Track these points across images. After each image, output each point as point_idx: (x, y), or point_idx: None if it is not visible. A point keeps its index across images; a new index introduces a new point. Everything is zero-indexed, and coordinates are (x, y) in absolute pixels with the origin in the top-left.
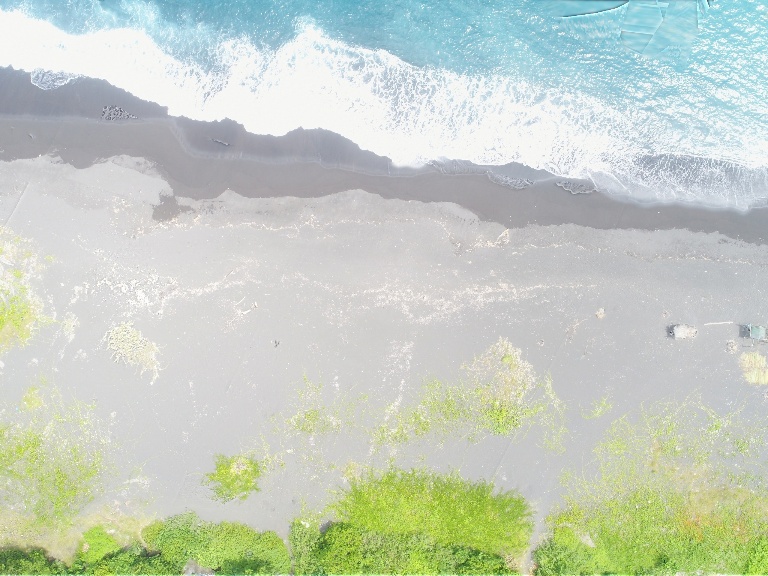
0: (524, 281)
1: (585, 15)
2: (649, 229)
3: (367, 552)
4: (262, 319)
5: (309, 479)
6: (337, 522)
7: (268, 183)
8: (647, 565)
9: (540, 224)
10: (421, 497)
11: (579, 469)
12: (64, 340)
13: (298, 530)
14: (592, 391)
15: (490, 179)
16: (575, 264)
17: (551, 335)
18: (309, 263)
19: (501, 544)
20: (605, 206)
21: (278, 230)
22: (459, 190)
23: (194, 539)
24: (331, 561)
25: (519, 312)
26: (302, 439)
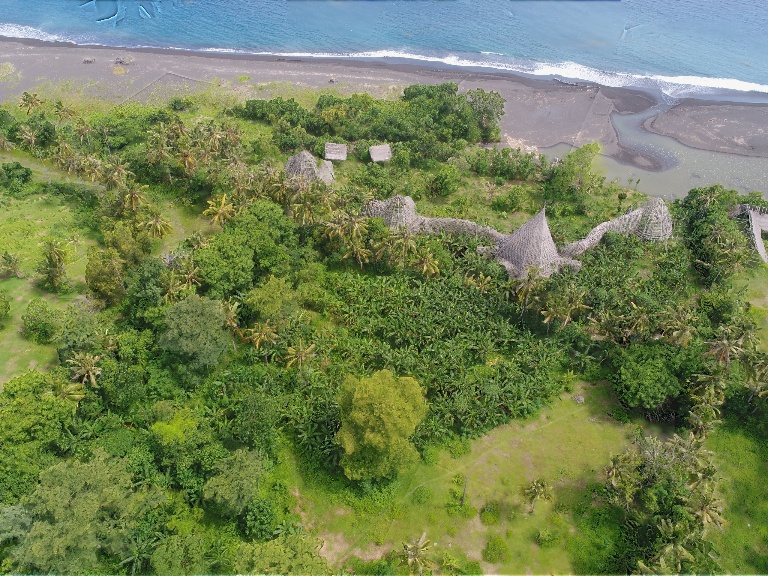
0: None
1: (105, 20)
2: None
3: None
4: None
5: None
6: None
7: None
8: None
9: None
10: None
11: None
12: None
13: None
14: None
15: (37, 40)
16: None
17: None
18: None
19: None
20: None
21: None
22: None
23: None
24: None
25: (20, 57)
26: None
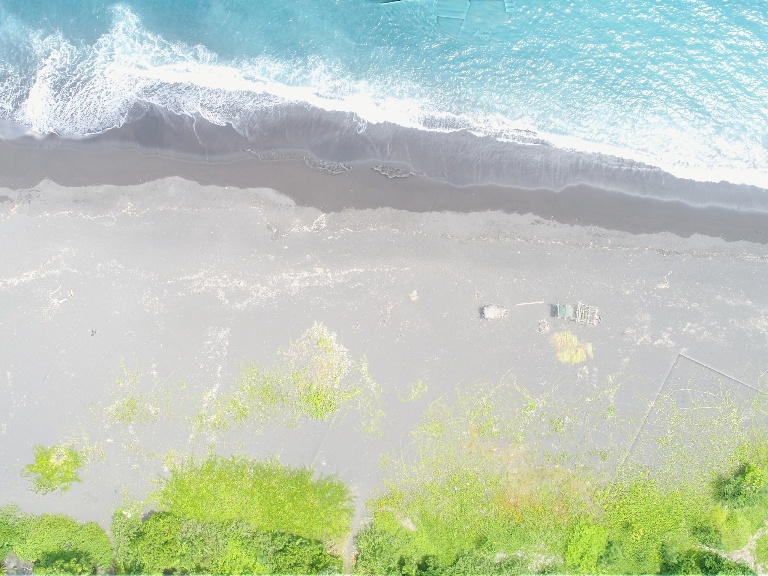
0: (339, 265)
1: (401, 1)
2: (464, 211)
3: (185, 540)
4: (78, 308)
5: (130, 468)
6: (159, 511)
7: (86, 172)
8: (468, 547)
9: (356, 208)
10: (241, 484)
11: (398, 452)
12: None
13: (118, 520)
14: (408, 374)
15: (307, 164)
16: (390, 247)
17: (365, 318)
18: (125, 251)
19: (322, 530)
20: (421, 189)
21: (95, 218)
22: (276, 176)
23: (11, 531)
24: (144, 550)
25: (333, 296)
26: (121, 428)
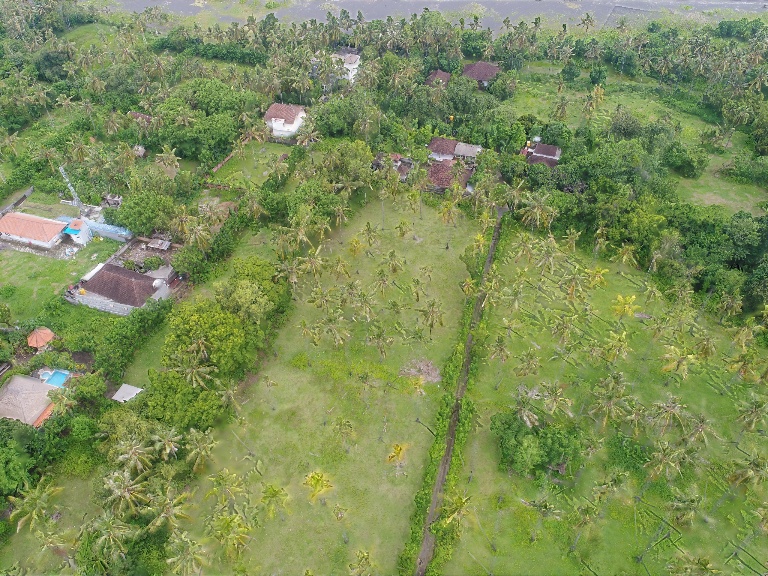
0: None
1: None
2: None
3: None
4: None
5: None
6: None
7: None
8: None
9: None
10: None
11: None
12: (303, 7)
13: None
14: None
15: None
16: None
17: None
18: None
19: None
20: None
21: None
22: None
23: None
24: None
25: None
26: None
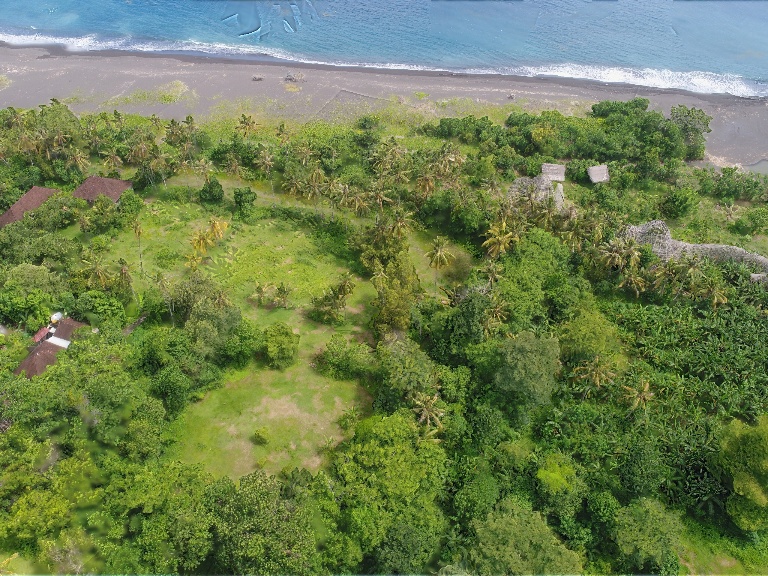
0: None
1: (247, 34)
2: None
3: None
4: None
5: None
6: None
7: None
8: None
9: (208, 63)
10: None
11: None
12: None
13: None
14: None
15: None
16: None
17: None
18: (99, 65)
19: None
20: None
21: None
22: None
23: None
24: None
25: None
26: None
